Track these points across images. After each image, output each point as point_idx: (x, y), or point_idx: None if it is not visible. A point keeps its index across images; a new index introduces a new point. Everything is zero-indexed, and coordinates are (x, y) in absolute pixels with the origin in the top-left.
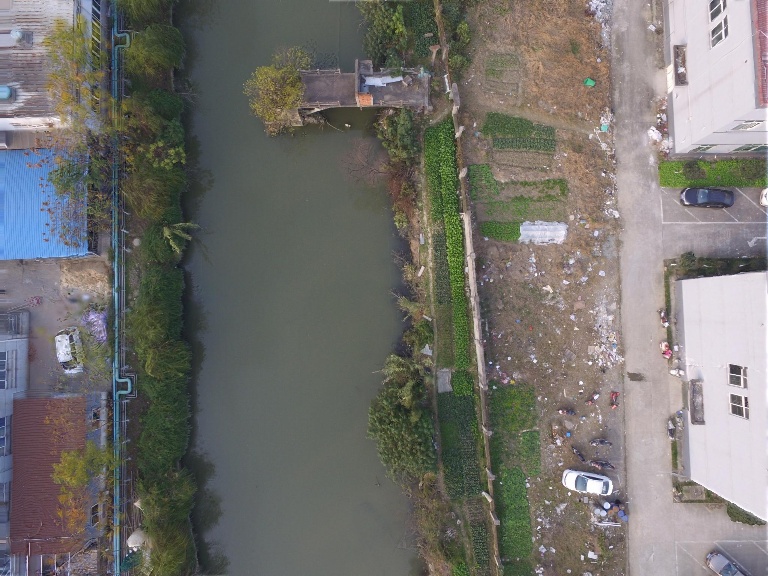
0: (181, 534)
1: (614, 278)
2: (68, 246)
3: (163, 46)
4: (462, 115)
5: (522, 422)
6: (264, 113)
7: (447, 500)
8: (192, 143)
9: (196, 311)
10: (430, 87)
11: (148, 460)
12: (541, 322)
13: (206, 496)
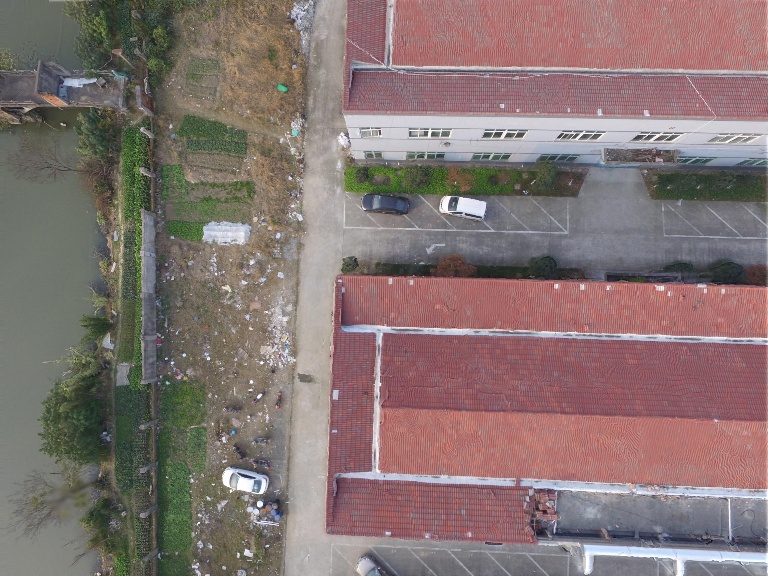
0: None
1: (292, 280)
2: None
3: None
4: (158, 117)
5: (191, 418)
6: None
7: (117, 492)
8: None
9: None
10: (126, 89)
11: None
12: (218, 321)
13: None
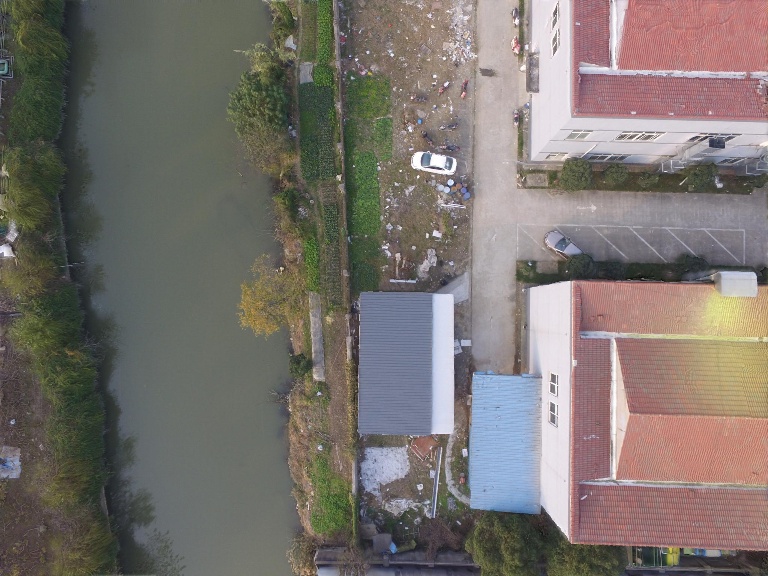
0: (43, 194)
1: None
2: None
3: None
4: None
5: (377, 110)
6: None
7: (303, 183)
8: None
9: (81, 18)
10: None
11: (17, 130)
12: (400, 20)
13: (81, 192)
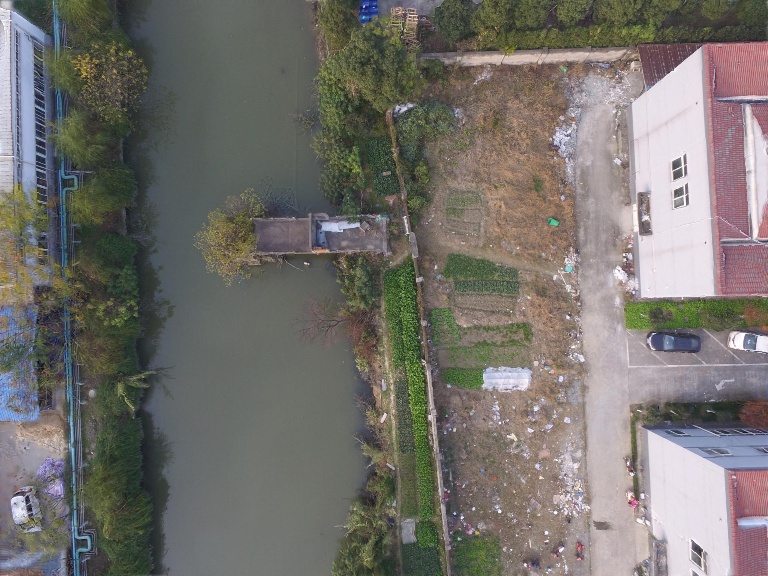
0: None
1: (579, 425)
2: (19, 412)
3: (111, 195)
4: (422, 258)
5: (487, 574)
6: (216, 269)
7: None
8: (148, 282)
9: (157, 456)
10: (389, 231)
11: None
12: (506, 471)
13: None
